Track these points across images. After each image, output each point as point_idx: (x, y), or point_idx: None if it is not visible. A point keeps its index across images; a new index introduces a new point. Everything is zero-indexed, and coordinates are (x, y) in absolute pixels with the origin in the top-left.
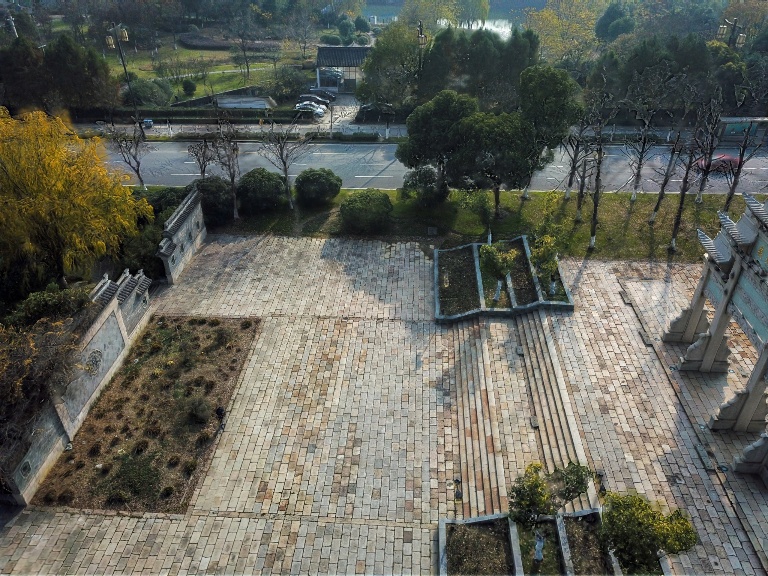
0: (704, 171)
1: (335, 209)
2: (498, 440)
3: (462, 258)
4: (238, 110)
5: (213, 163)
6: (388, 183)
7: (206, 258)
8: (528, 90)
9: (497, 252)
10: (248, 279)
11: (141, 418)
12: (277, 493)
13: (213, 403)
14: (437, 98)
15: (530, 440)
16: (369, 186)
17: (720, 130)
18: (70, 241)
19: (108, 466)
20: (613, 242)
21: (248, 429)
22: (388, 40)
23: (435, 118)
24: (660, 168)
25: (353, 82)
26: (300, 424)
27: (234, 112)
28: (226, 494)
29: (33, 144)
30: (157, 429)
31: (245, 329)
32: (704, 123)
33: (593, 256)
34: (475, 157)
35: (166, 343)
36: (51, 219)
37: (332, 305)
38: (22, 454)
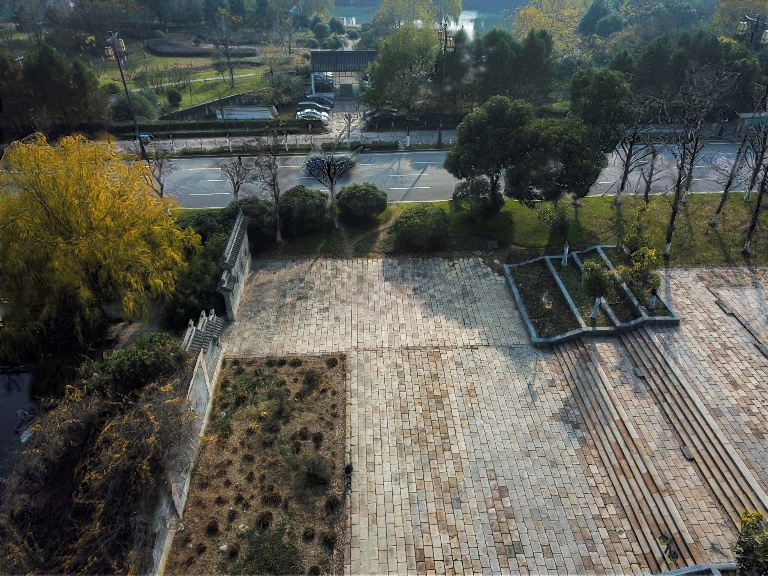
0: (755, 170)
1: (383, 226)
2: (658, 477)
3: (537, 273)
4: (241, 121)
5: (246, 182)
6: (427, 194)
7: (260, 288)
8: (579, 93)
9: (603, 269)
10: (315, 309)
11: (253, 484)
12: (438, 561)
13: (328, 458)
14: (489, 105)
15: (691, 474)
16: (409, 199)
17: (739, 126)
18: (124, 281)
19: (236, 547)
20: (685, 248)
21: (378, 486)
22: (397, 43)
23: (491, 126)
24: (723, 169)
25: (349, 87)
26: (433, 475)
27: (237, 123)
28: (382, 568)
29: (76, 174)
30: (277, 496)
31: (332, 368)
32: (725, 119)
33: (672, 264)
34: (544, 166)
35: (250, 391)
36: (105, 259)
37: (417, 333)
38: (151, 549)
